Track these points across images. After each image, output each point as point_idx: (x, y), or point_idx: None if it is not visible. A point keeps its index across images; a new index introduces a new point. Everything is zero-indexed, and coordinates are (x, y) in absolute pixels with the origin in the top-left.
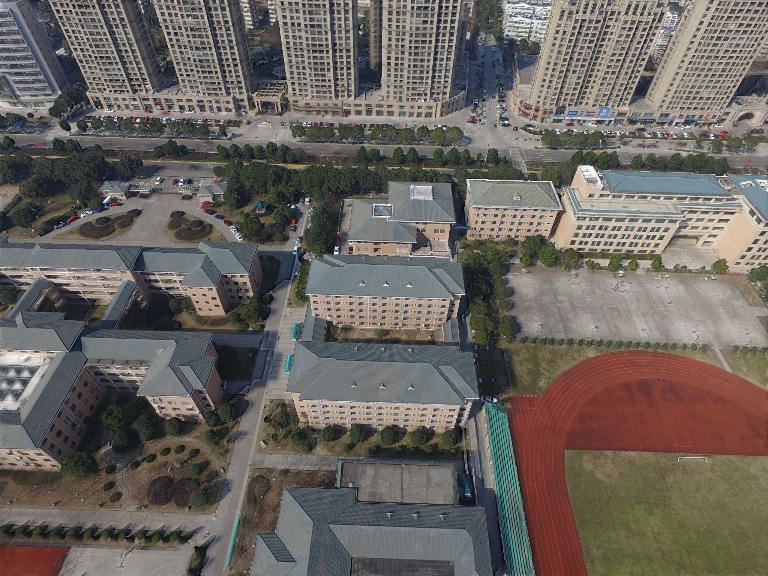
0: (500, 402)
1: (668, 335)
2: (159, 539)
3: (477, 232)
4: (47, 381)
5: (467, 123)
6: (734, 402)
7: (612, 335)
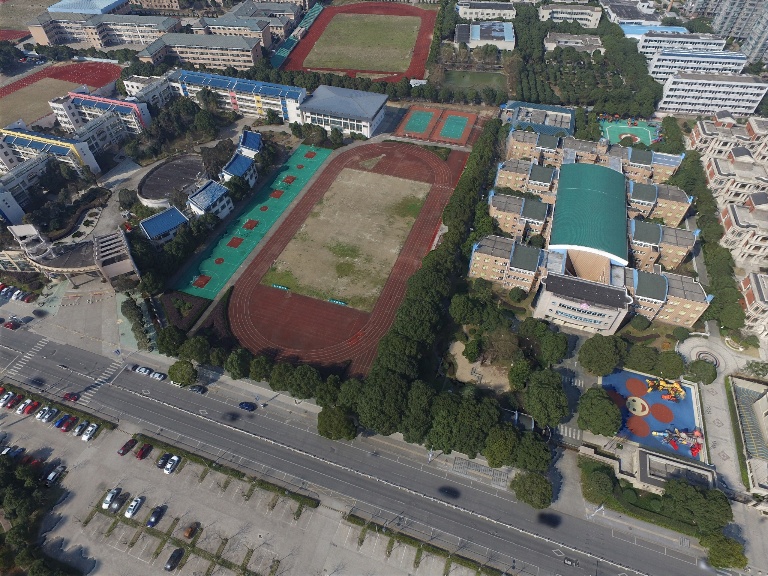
0: (322, 4)
1: (398, 0)
2: None
3: None
4: None
5: None
6: (407, 9)
7: None
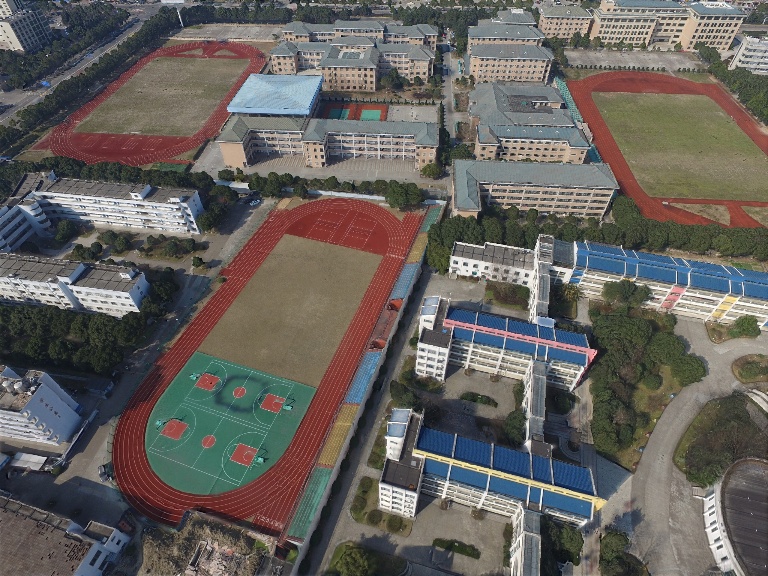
0: (562, 78)
1: None
2: (424, 104)
3: (546, 36)
4: (370, 52)
5: (534, 3)
6: (674, 83)
7: (617, 67)
